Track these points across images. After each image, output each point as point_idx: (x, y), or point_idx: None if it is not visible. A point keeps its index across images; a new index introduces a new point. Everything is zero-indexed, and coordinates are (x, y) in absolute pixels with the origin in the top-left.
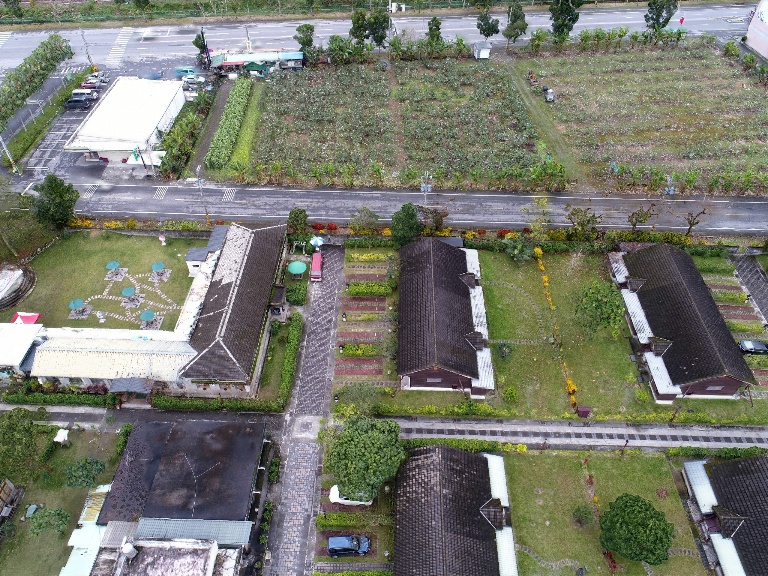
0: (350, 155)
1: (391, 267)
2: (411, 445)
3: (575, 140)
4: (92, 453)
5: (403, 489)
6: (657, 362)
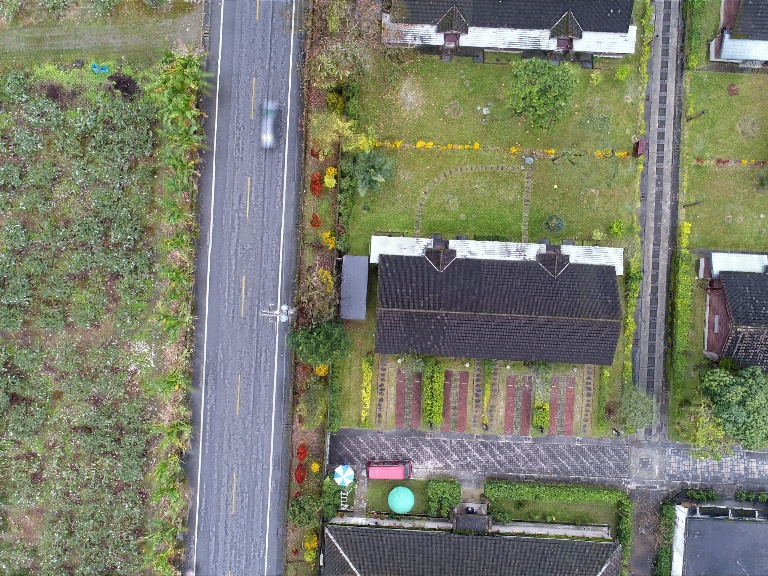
0: (82, 427)
1: (415, 367)
2: (685, 350)
3: (34, 6)
4: None
5: (764, 365)
6: (590, 40)
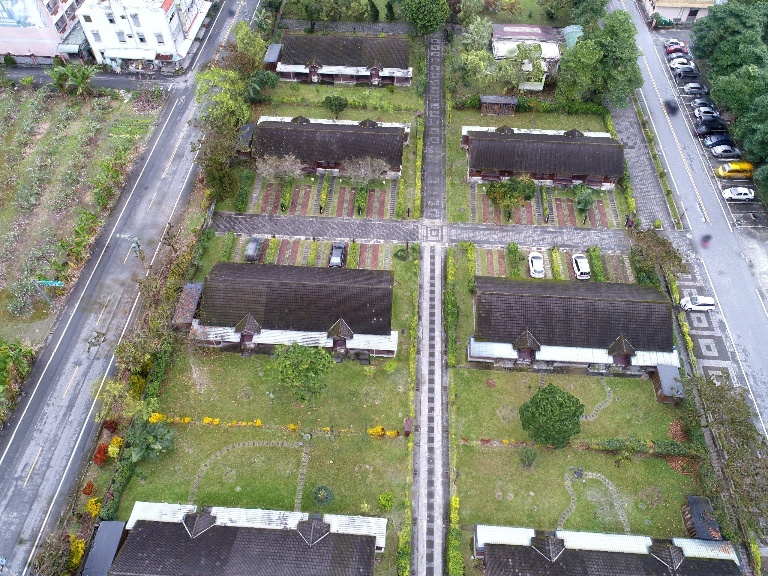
0: None
1: None
2: None
3: None
4: None
5: None
6: (360, 340)
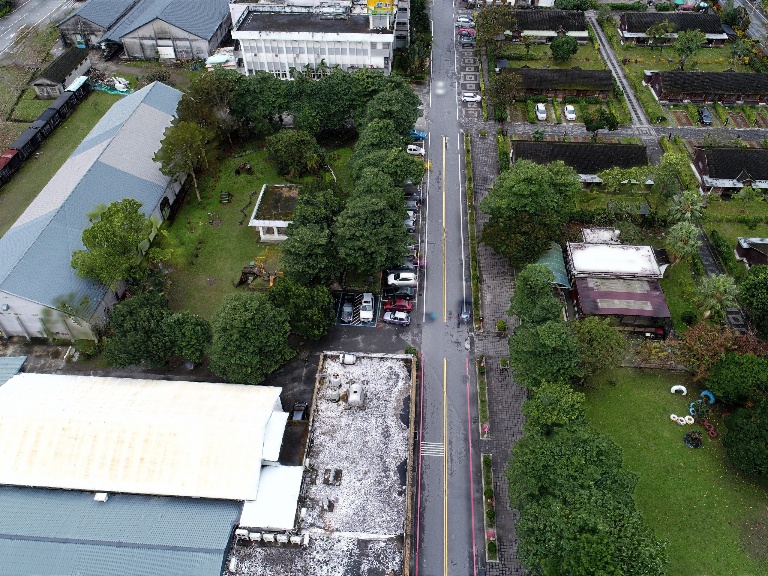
0: None
1: None
2: None
3: None
4: None
5: None
6: None
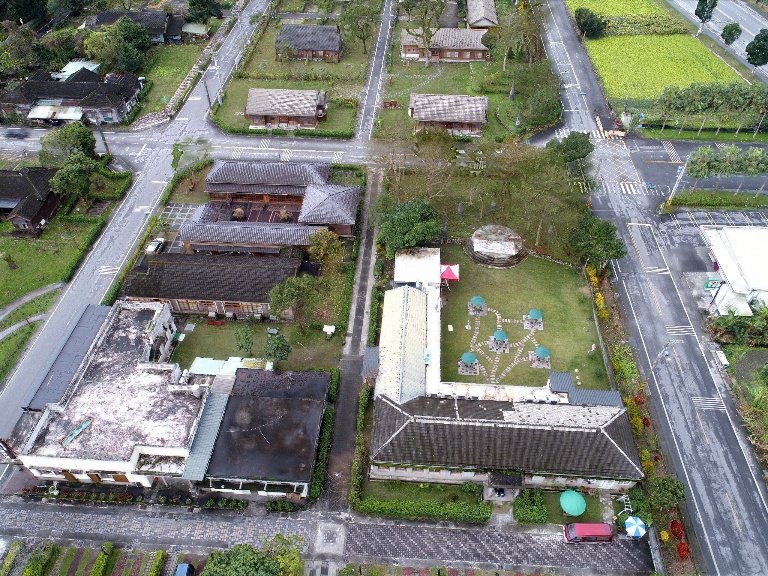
0: None
1: None
2: None
3: None
4: (320, 356)
5: None
6: None
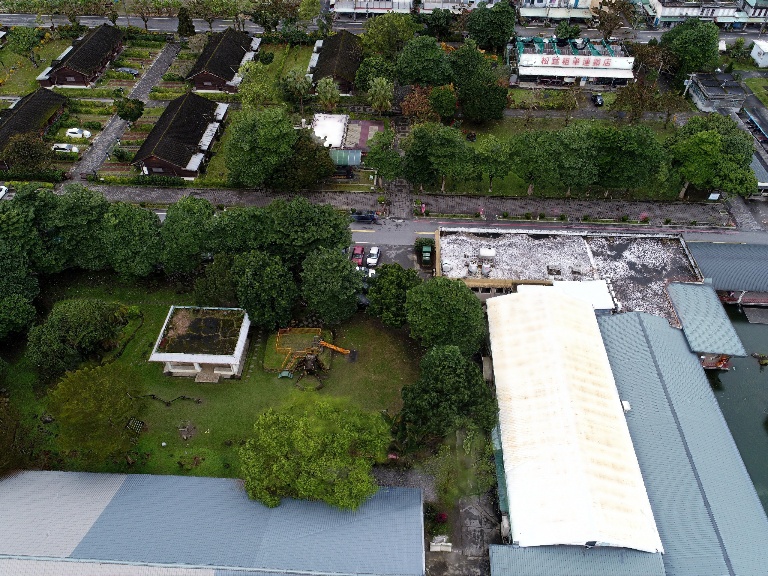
0: None
1: None
2: None
3: None
4: None
5: None
6: (49, 69)
